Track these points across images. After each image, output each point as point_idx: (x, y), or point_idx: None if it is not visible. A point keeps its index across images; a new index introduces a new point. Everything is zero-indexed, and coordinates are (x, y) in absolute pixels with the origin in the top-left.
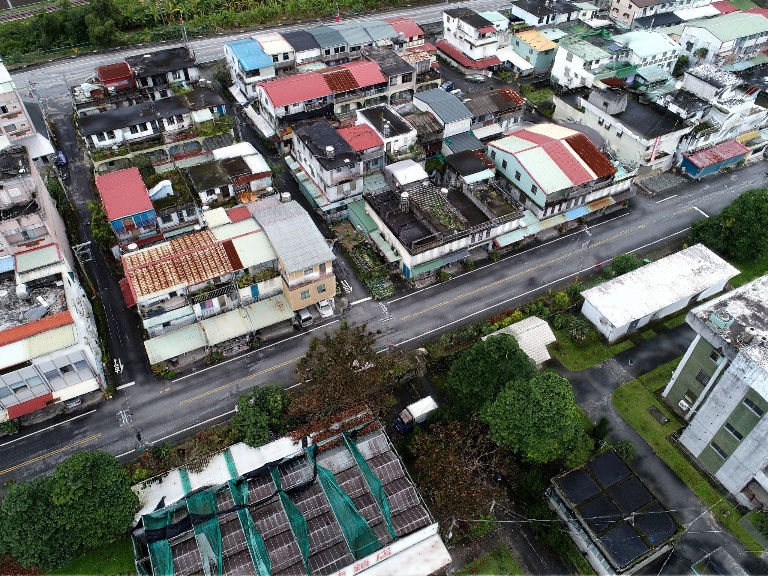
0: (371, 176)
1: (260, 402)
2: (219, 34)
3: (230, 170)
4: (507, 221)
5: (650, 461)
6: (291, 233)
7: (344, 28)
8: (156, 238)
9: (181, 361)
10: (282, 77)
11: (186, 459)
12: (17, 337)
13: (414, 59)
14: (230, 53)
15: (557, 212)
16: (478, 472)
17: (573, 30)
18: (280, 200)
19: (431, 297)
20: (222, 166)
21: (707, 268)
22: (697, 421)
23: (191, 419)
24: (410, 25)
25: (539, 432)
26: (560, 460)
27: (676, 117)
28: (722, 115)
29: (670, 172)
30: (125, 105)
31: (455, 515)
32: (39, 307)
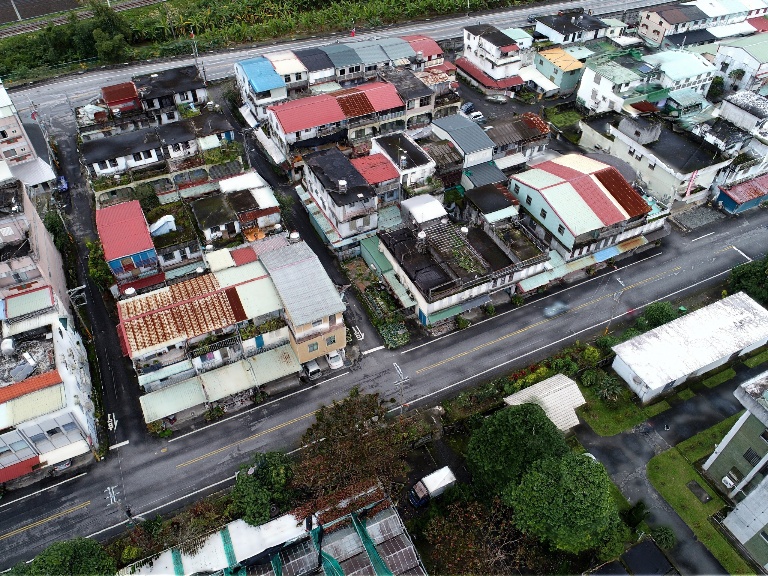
0: (386, 209)
1: (262, 472)
2: (231, 49)
3: (236, 205)
4: (532, 264)
5: (691, 547)
6: (299, 280)
7: (360, 46)
8: (157, 277)
9: (179, 417)
10: (294, 100)
11: (180, 538)
12: (0, 399)
13: (433, 81)
14: (240, 73)
15: (585, 253)
16: (500, 563)
17: (600, 48)
18: (288, 240)
19: (449, 347)
20: (228, 200)
21: (750, 321)
22: (745, 506)
23: (188, 486)
24: (429, 43)
25: (570, 523)
26: (592, 551)
27: (713, 148)
28: (764, 147)
29: (706, 206)
30: (130, 128)
31: None
32: (26, 364)
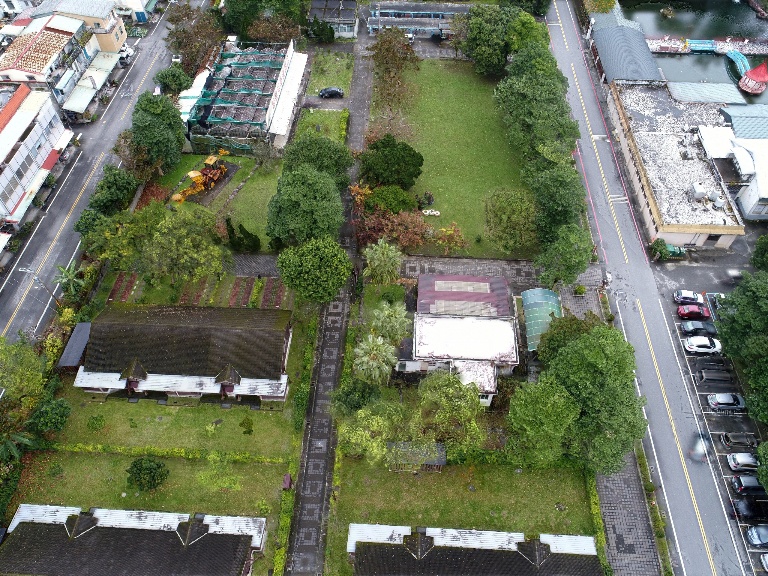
0: None
1: None
2: None
3: None
4: None
5: None
6: (75, 6)
7: None
8: None
9: None
10: None
11: None
12: (13, 110)
13: None
14: None
15: None
16: None
17: None
18: None
19: None
20: None
21: None
22: None
23: None
24: None
25: None
26: (302, 11)
27: None
28: None
29: None
30: None
31: (293, 38)
32: None
